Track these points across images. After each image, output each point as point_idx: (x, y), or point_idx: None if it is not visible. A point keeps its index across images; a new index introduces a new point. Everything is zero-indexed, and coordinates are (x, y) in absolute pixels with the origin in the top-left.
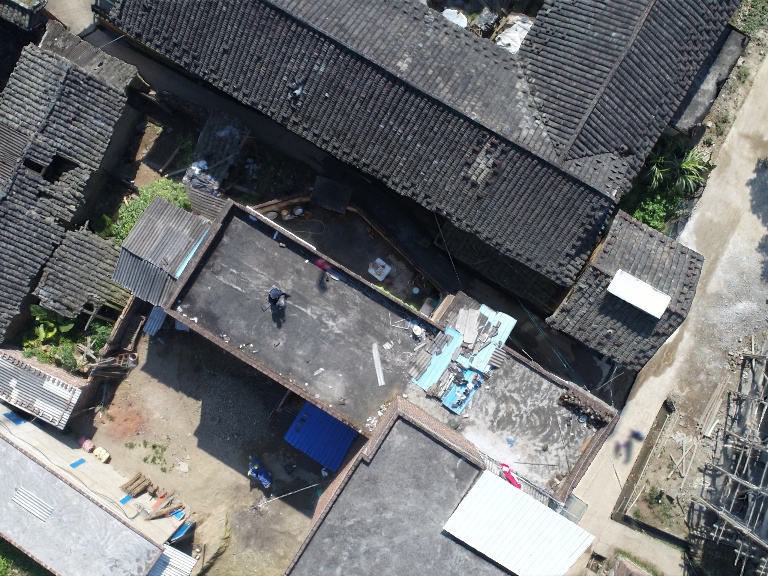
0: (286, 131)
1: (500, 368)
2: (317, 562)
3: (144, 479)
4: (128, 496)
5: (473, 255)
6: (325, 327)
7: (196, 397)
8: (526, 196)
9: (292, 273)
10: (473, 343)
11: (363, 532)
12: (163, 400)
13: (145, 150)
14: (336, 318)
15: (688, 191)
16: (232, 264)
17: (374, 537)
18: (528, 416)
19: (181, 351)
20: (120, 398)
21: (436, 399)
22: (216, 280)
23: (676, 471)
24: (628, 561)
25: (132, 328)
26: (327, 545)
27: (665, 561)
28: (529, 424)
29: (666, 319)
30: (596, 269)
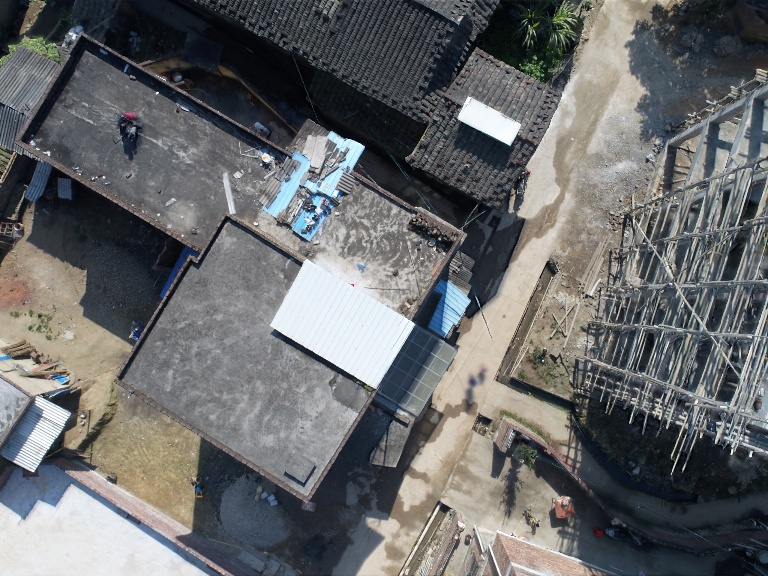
0: (168, 3)
1: (349, 194)
2: (149, 365)
3: (28, 346)
4: (7, 356)
5: (343, 108)
6: (176, 158)
7: (81, 266)
8: (376, 28)
9: (143, 105)
10: (320, 167)
11: (194, 334)
12: (49, 270)
13: (29, 24)
14: (187, 149)
15: (560, 46)
16: (84, 98)
17: (205, 339)
18: (378, 242)
19: (66, 221)
20: (6, 269)
21: (287, 226)
22: (68, 114)
23: (559, 330)
24: (512, 420)
25: (16, 198)
26: (159, 348)
27: (551, 422)
28: (379, 249)
29: (519, 149)
30: (447, 99)
